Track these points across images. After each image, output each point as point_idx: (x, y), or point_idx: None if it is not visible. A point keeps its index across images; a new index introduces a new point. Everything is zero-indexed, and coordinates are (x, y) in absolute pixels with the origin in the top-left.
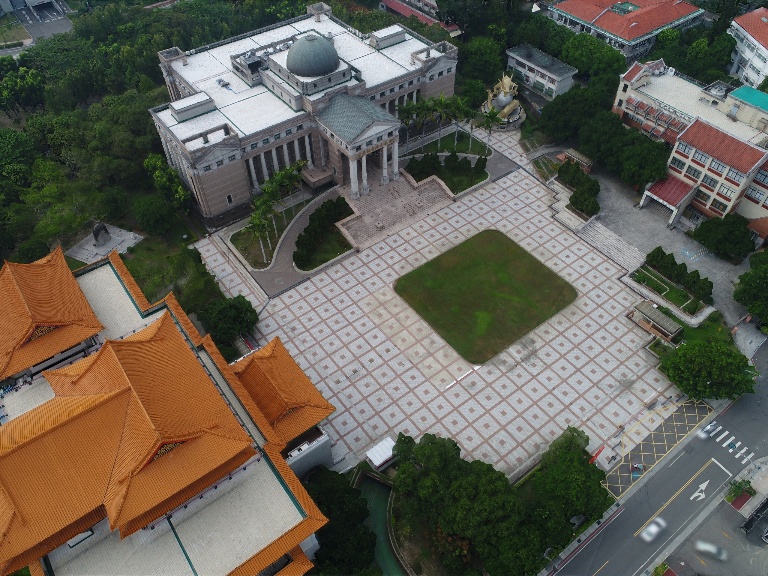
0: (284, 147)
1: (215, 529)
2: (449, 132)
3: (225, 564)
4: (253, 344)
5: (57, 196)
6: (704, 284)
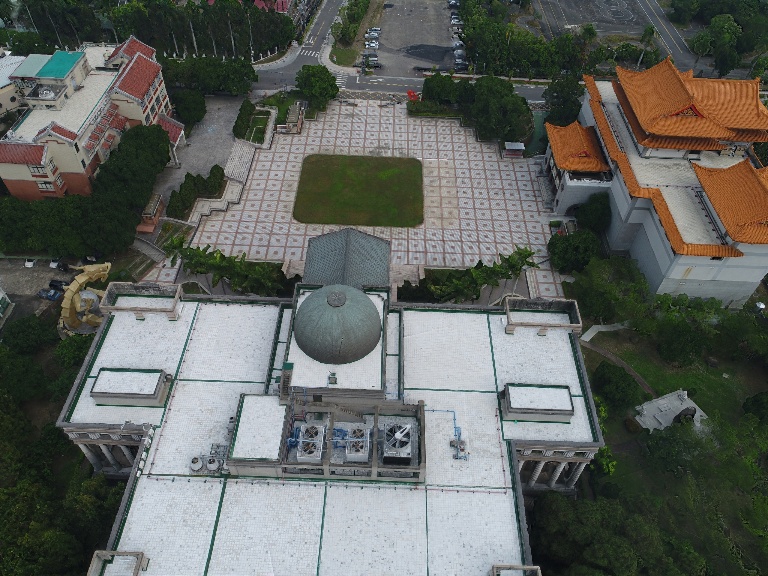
0: None
1: None
2: None
3: None
4: None
5: None
6: None
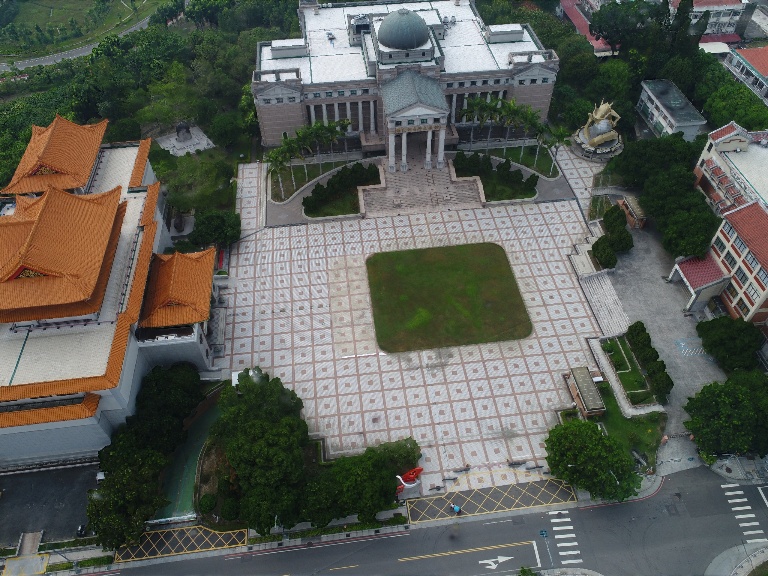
0: (347, 105)
1: (48, 353)
2: (530, 144)
3: (34, 378)
4: (226, 256)
5: (174, 94)
6: (660, 378)
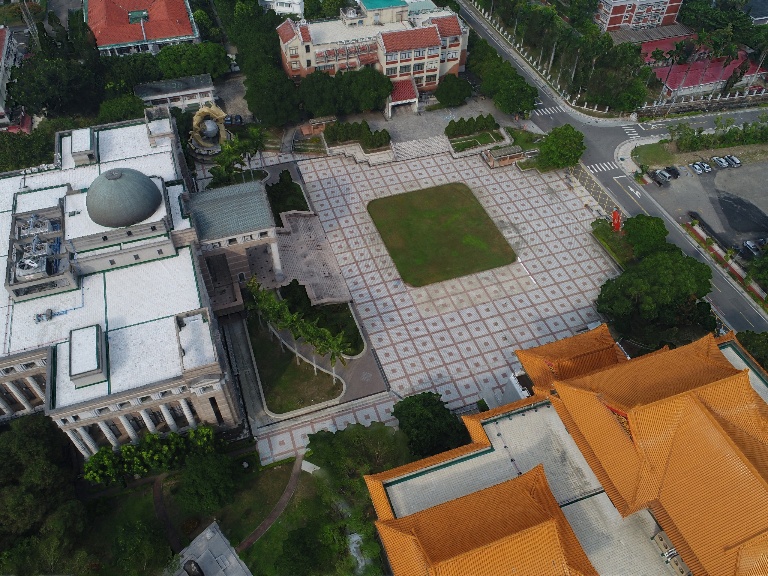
0: None
1: None
2: None
3: None
4: None
5: None
6: (492, 118)
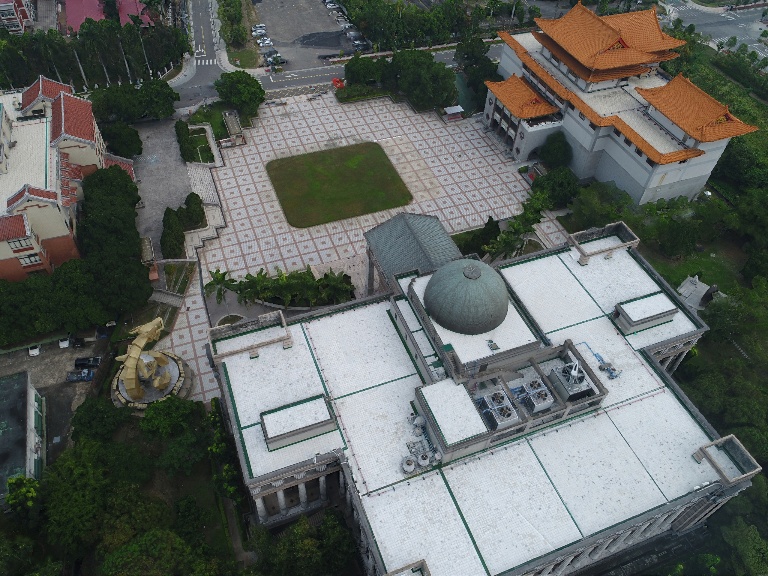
0: None
1: None
2: None
3: None
4: None
5: None
6: None
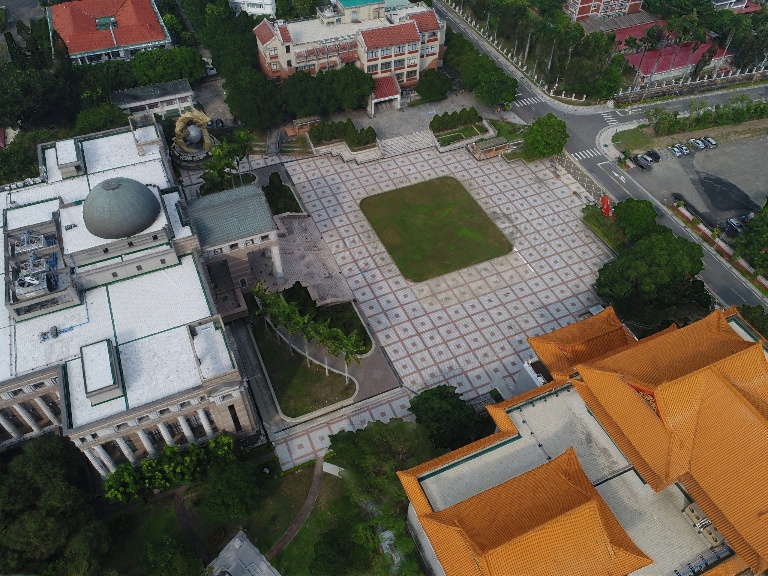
0: None
1: None
2: None
3: None
4: None
5: None
6: (475, 111)
